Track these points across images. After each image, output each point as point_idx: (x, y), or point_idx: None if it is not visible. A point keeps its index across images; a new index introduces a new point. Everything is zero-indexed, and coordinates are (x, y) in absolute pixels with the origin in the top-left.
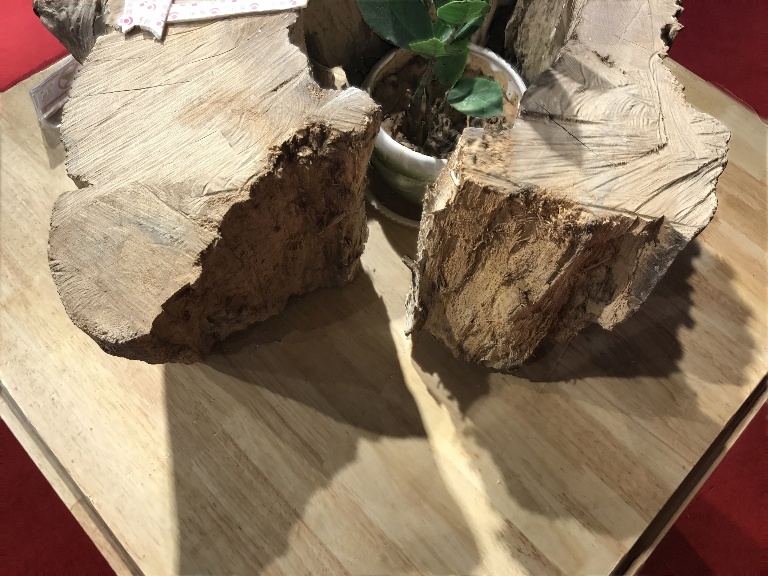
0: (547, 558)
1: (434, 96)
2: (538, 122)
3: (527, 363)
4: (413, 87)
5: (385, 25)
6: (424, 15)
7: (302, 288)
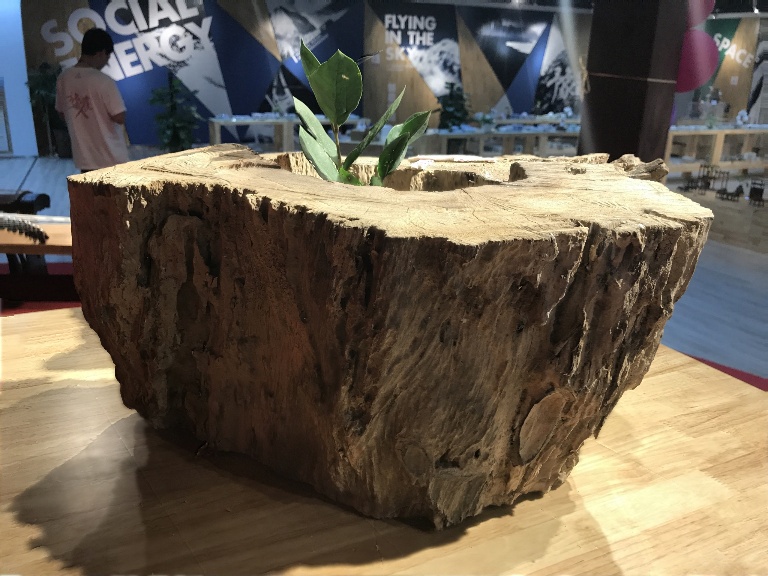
0: (6, 390)
1: None
2: None
3: (140, 421)
4: None
5: None
6: None
7: None
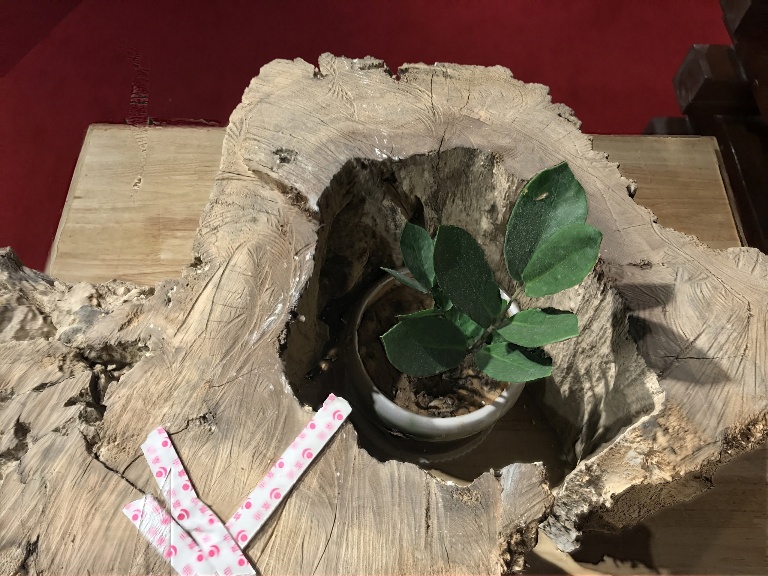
0: None
1: None
2: (673, 371)
3: None
4: None
5: (427, 363)
6: (448, 326)
7: None
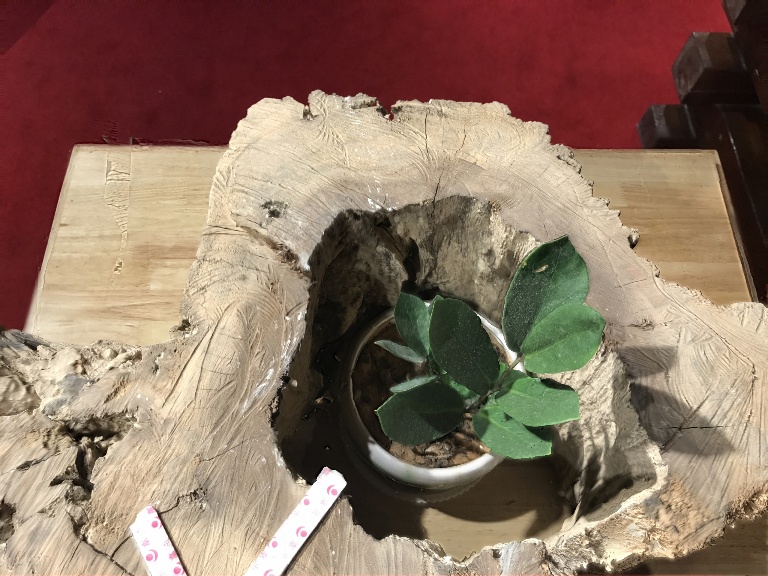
0: None
1: (398, 374)
2: (676, 442)
3: None
4: (379, 385)
5: (423, 430)
6: (444, 389)
7: None
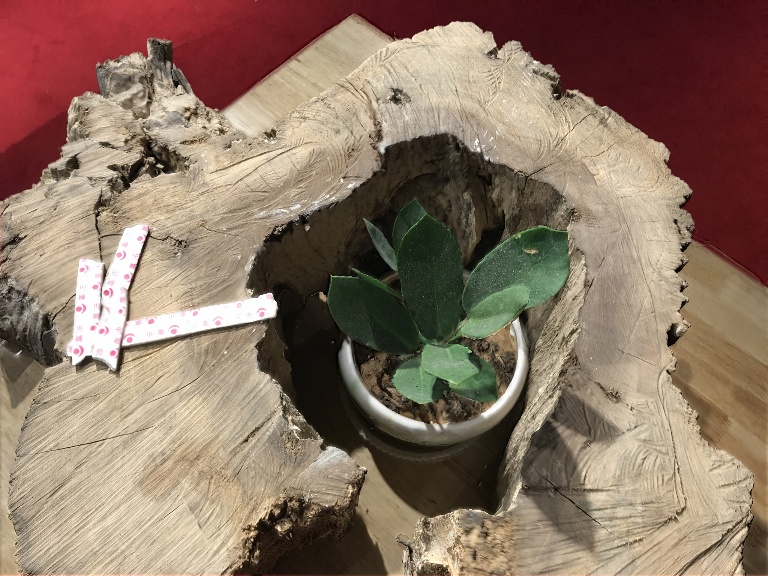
0: None
1: None
2: (542, 496)
3: None
4: None
5: (364, 331)
6: (406, 316)
7: (291, 546)
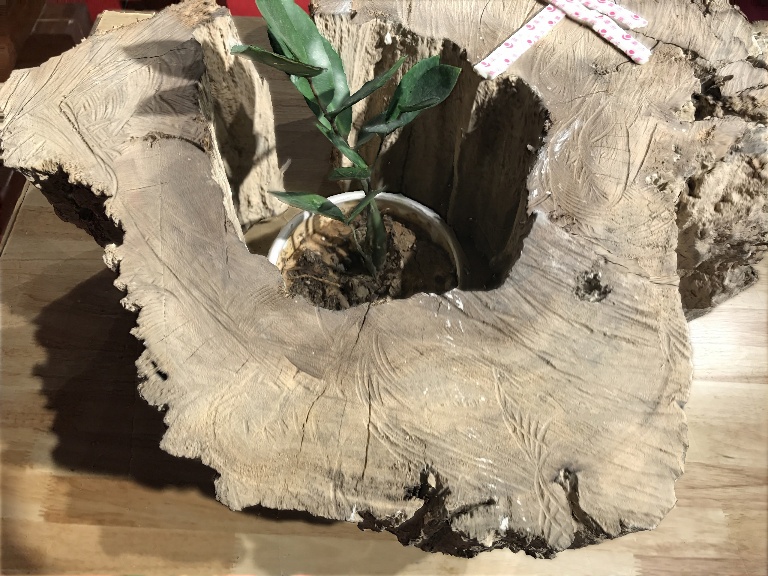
0: None
1: None
2: None
3: None
4: None
5: None
6: None
7: None
